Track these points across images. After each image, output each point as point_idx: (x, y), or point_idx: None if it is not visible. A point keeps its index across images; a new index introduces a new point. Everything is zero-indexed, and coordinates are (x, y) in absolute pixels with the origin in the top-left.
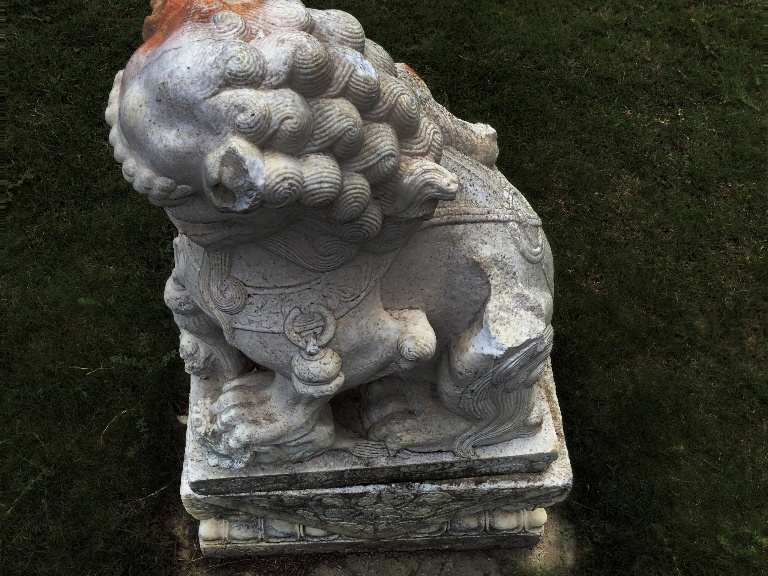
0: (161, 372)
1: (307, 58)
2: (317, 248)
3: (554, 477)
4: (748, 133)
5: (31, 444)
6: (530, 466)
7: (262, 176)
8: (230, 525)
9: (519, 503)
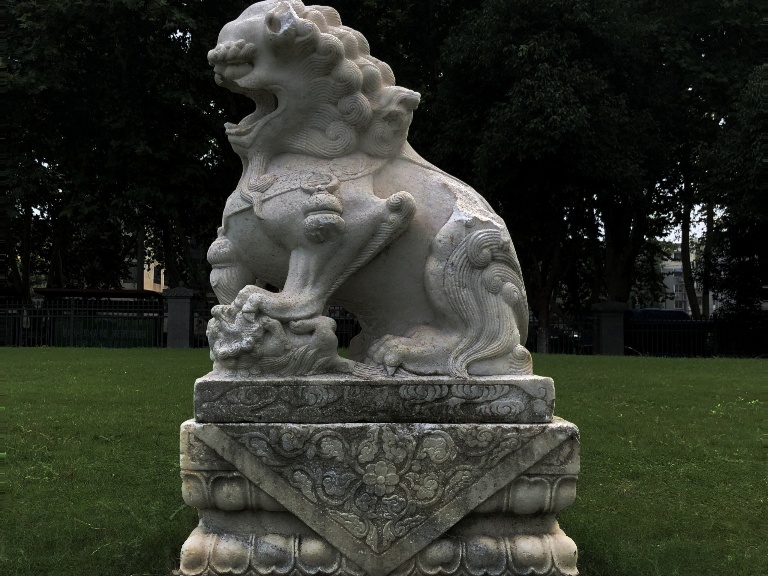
0: (165, 530)
1: None
2: (328, 134)
3: None
4: None
5: (14, 556)
6: (530, 407)
7: None
8: (218, 539)
9: (532, 478)
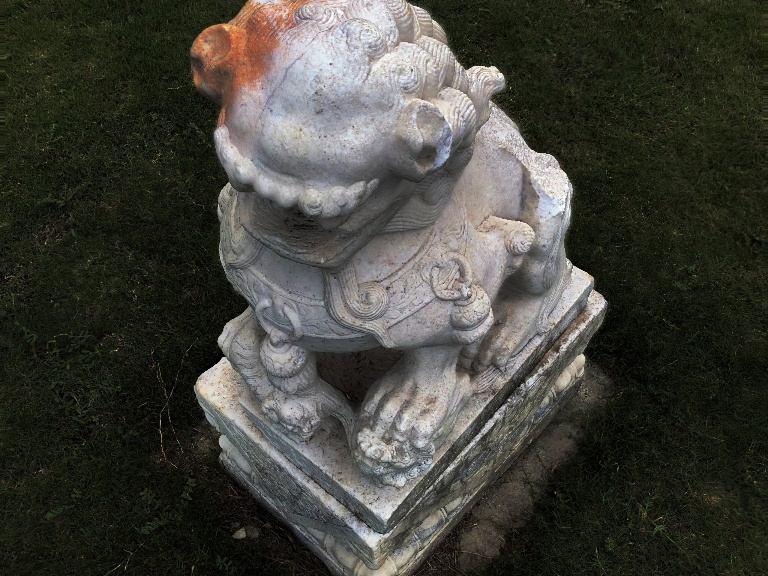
0: (189, 510)
1: (399, 6)
2: (429, 199)
3: (595, 305)
4: None
5: None
6: (579, 308)
7: None
8: (392, 558)
9: (577, 350)
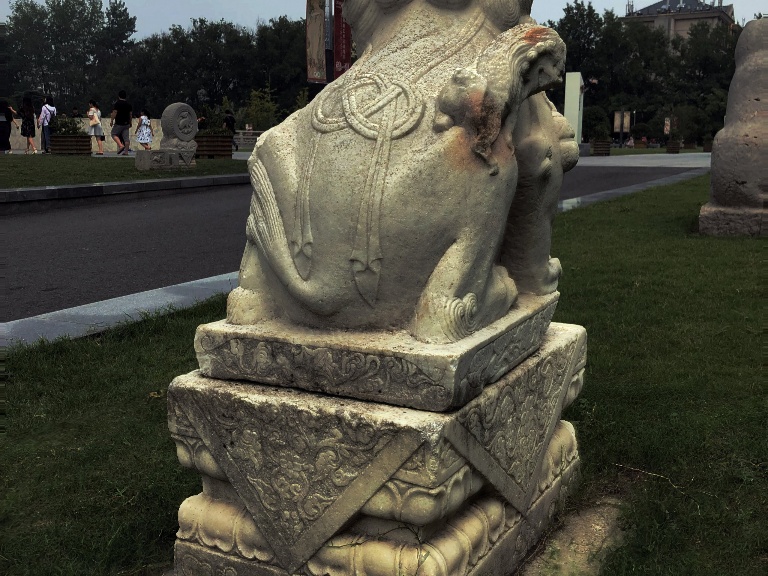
0: None
1: None
2: None
3: (188, 375)
4: None
5: None
6: None
7: None
8: None
9: None
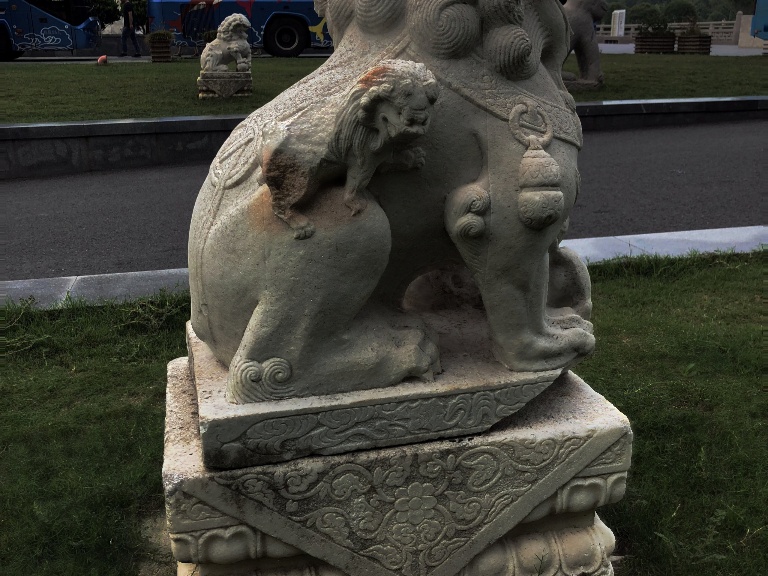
0: None
1: None
2: None
3: (187, 359)
4: None
5: None
6: None
7: None
8: None
9: None
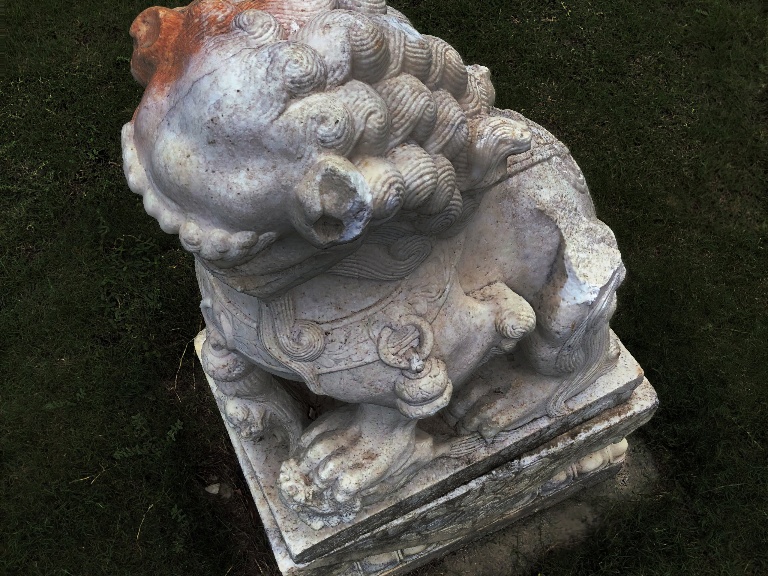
0: (171, 449)
1: (364, 37)
2: (395, 254)
3: (641, 401)
4: (633, 6)
5: None
6: (618, 399)
7: (367, 190)
8: None
9: (609, 439)
